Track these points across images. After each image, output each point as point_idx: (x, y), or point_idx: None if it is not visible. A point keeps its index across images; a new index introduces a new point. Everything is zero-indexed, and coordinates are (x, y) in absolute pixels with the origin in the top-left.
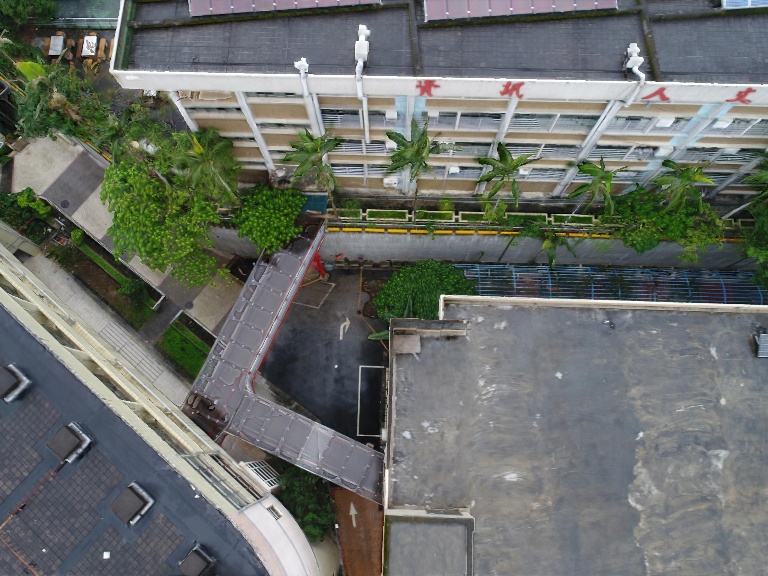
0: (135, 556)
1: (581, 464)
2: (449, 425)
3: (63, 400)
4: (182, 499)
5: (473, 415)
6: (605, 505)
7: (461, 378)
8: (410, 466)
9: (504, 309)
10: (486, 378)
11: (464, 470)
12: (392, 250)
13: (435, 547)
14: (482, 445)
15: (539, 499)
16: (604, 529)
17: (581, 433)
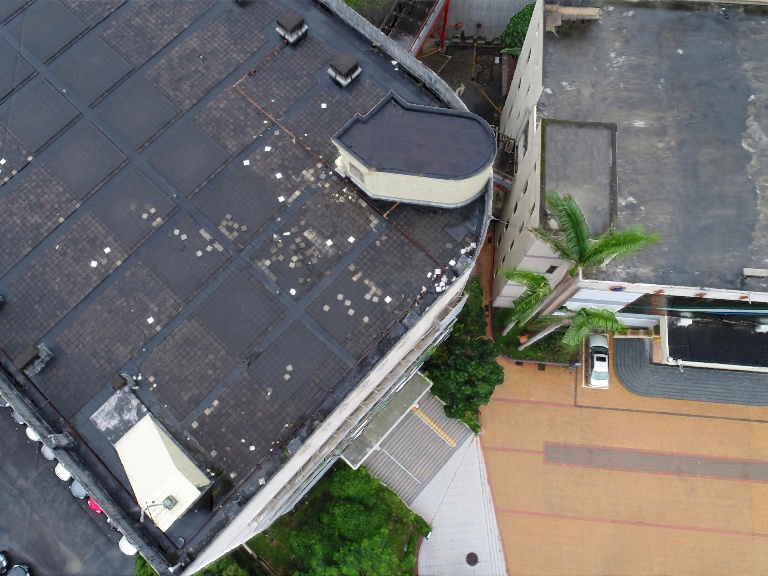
0: (347, 107)
1: (700, 116)
2: (585, 84)
3: (283, 0)
4: (384, 70)
5: (606, 78)
6: (721, 147)
7: (595, 51)
8: (551, 113)
9: (632, 1)
10: (616, 51)
11: (598, 118)
12: (509, 15)
13: (584, 143)
14: (614, 100)
15: (664, 140)
16: (720, 164)
17: (700, 94)
